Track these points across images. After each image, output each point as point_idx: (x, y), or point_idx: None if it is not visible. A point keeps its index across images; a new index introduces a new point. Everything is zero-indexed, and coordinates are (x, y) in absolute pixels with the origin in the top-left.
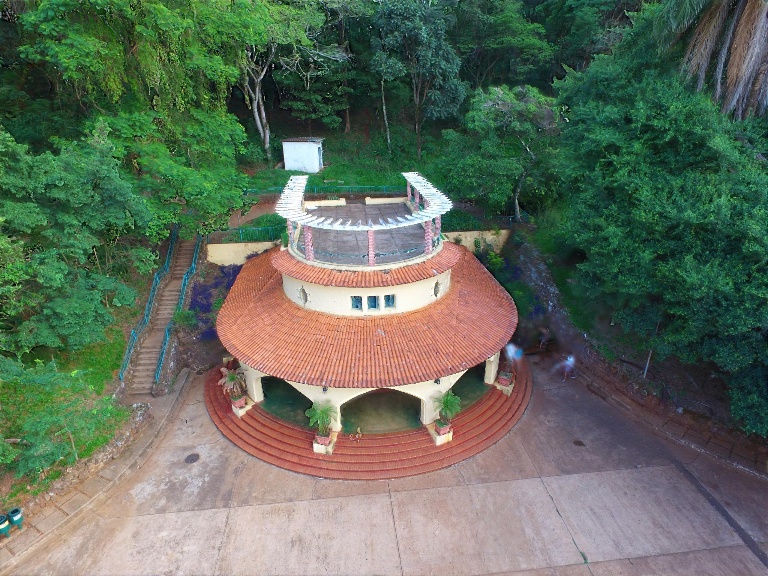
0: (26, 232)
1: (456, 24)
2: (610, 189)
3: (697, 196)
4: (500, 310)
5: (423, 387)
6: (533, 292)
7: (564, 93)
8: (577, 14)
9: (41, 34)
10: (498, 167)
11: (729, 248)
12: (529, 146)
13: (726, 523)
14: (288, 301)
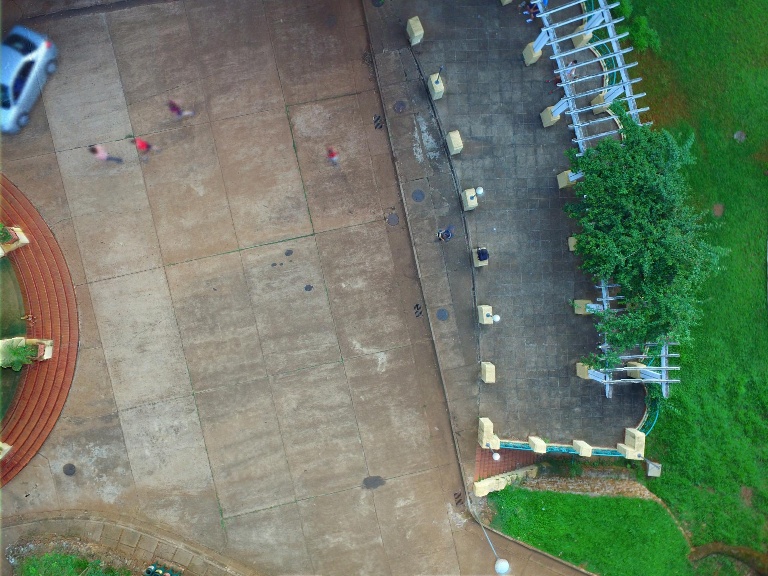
0: None
1: None
2: None
3: None
4: None
5: None
6: None
7: None
8: None
9: None
10: None
11: None
12: None
13: (87, 16)
14: None
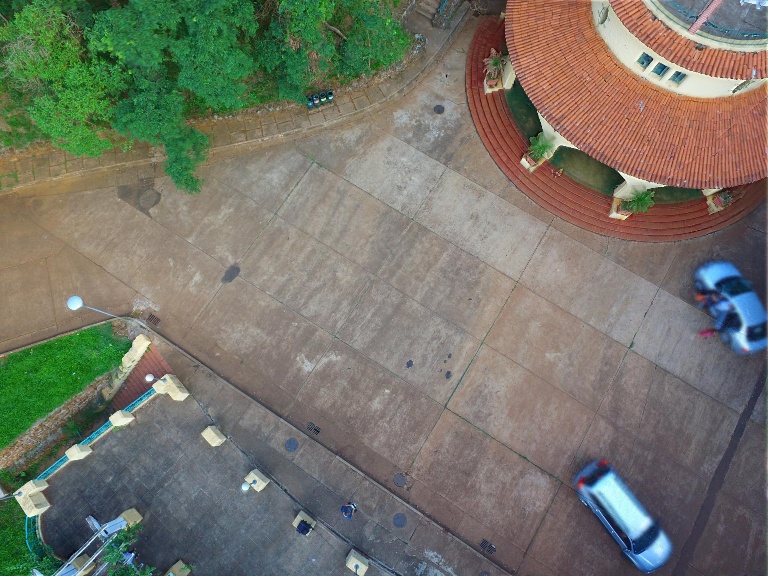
0: None
1: None
2: None
3: None
4: None
5: None
6: None
7: None
8: None
9: None
10: None
11: None
12: None
13: (748, 399)
14: (588, 5)
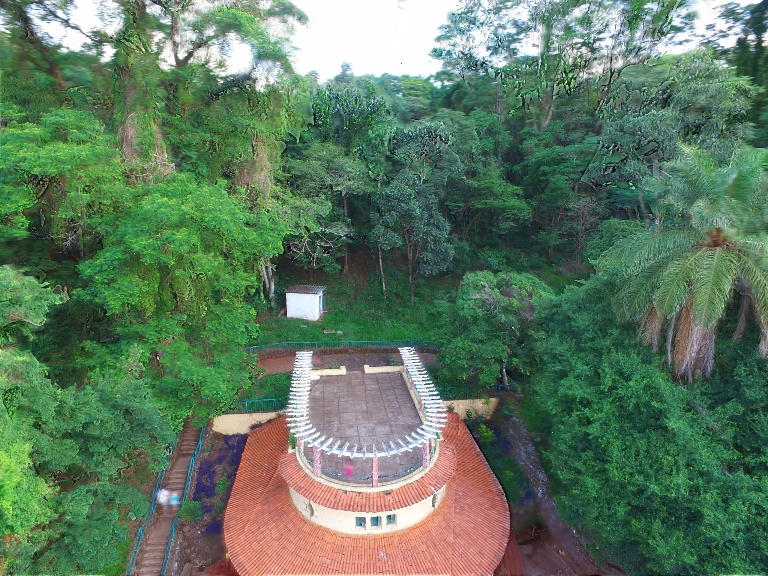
0: (61, 470)
1: None
2: None
3: (660, 463)
4: (493, 513)
5: None
6: (523, 472)
7: (542, 311)
8: (550, 179)
9: (93, 281)
10: (486, 351)
11: (691, 516)
12: None
13: None
14: (294, 509)
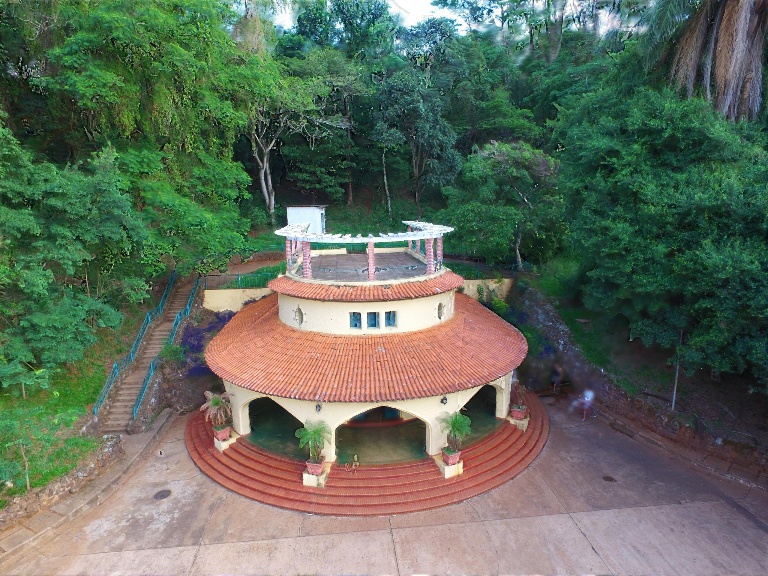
0: (16, 236)
1: (451, 111)
2: (613, 195)
3: (705, 184)
4: (508, 338)
5: (428, 407)
6: (541, 334)
7: (557, 130)
8: (561, 101)
9: (63, 66)
10: (497, 211)
11: (747, 232)
12: (526, 197)
13: None
14: (283, 325)
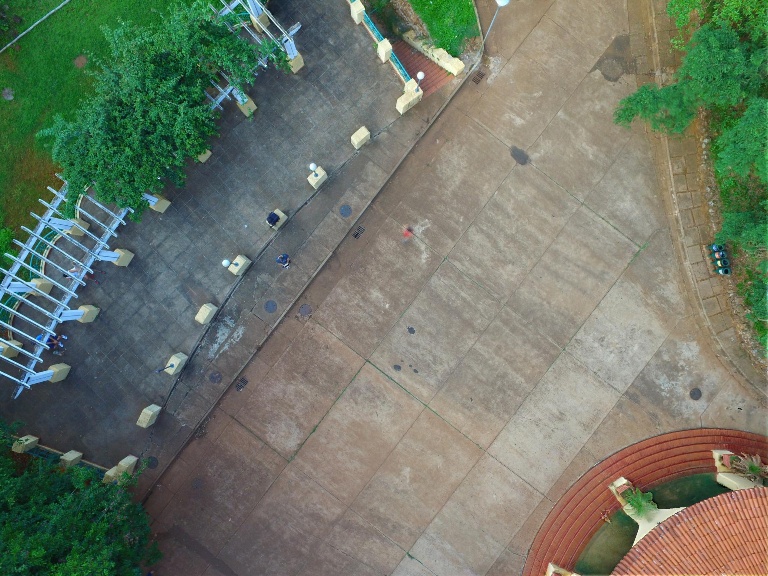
0: None
1: None
2: None
3: None
4: None
5: None
6: None
7: None
8: None
9: None
10: None
11: None
12: None
13: None
14: None
